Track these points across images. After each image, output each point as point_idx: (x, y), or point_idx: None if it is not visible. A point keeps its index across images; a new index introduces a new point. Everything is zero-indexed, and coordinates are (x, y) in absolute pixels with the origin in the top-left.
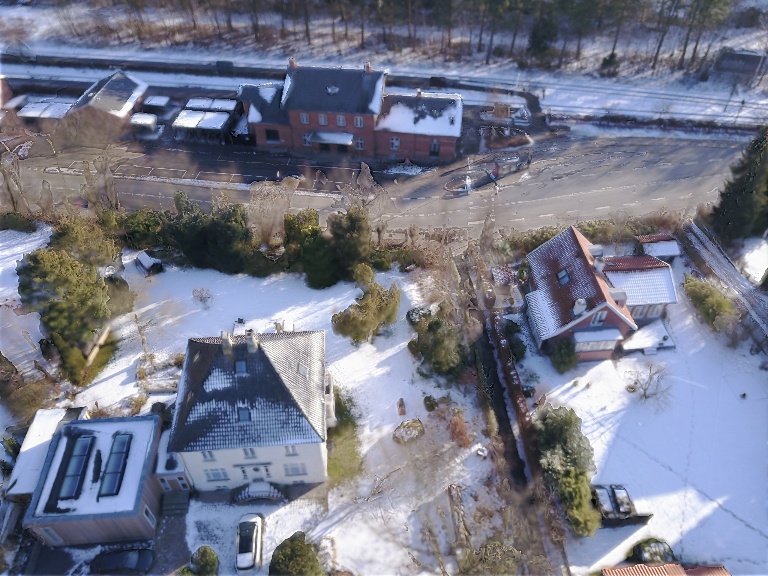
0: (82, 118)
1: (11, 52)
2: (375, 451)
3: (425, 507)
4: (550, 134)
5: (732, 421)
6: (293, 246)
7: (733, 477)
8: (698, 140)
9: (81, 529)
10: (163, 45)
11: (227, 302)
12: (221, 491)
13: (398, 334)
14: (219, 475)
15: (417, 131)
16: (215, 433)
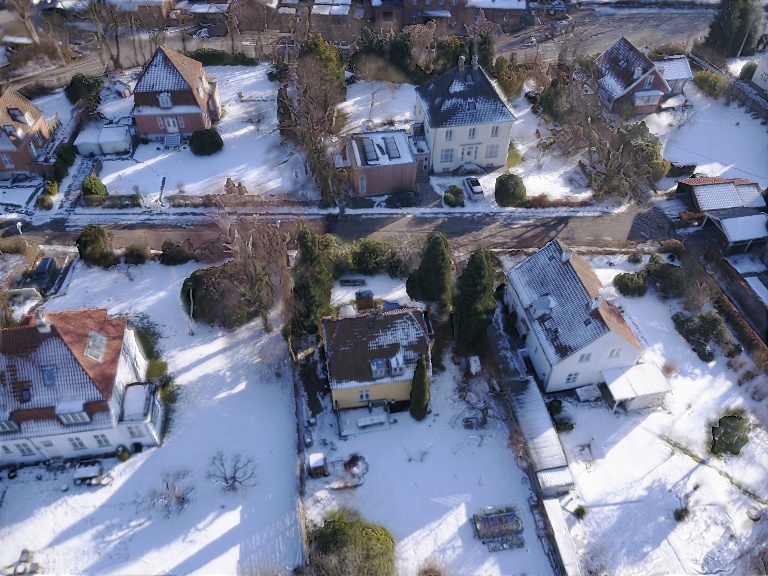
0: (243, 10)
1: None
2: (529, 153)
3: (567, 172)
4: (582, 13)
5: (732, 135)
6: (441, 63)
7: (737, 157)
8: (685, 13)
9: (381, 178)
10: None
11: (405, 96)
12: (445, 172)
13: (522, 106)
14: (448, 157)
15: (495, 6)
16: (456, 117)
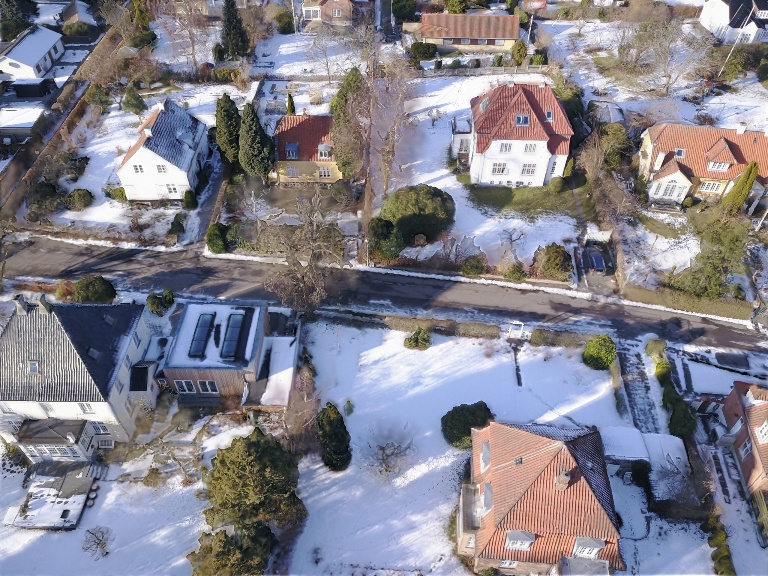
0: None
1: None
2: None
3: None
4: None
5: None
6: None
7: None
8: None
9: None
10: None
11: (77, 567)
12: None
13: None
14: None
15: None
16: None
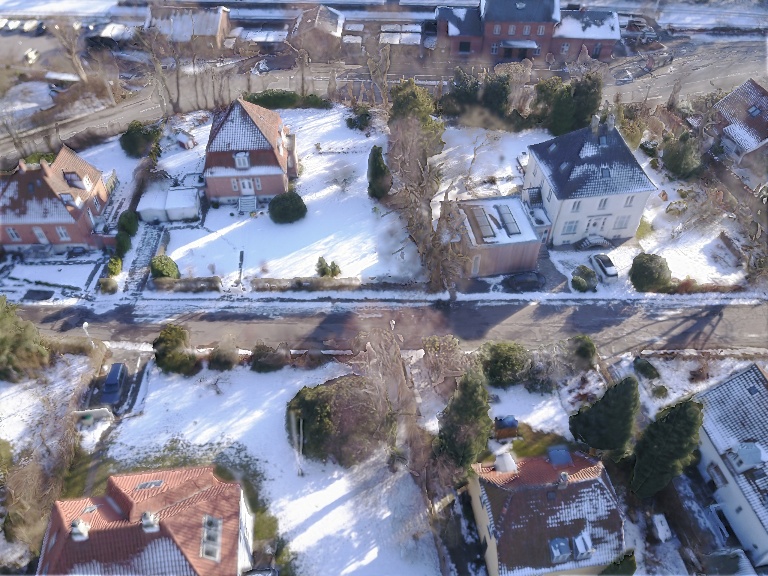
0: (305, 39)
1: None
2: (658, 220)
3: (707, 246)
4: (676, 42)
5: None
6: (540, 107)
7: None
8: None
9: (498, 258)
10: None
11: (502, 146)
12: (565, 245)
13: (637, 159)
14: (570, 229)
15: (587, 36)
16: (588, 186)
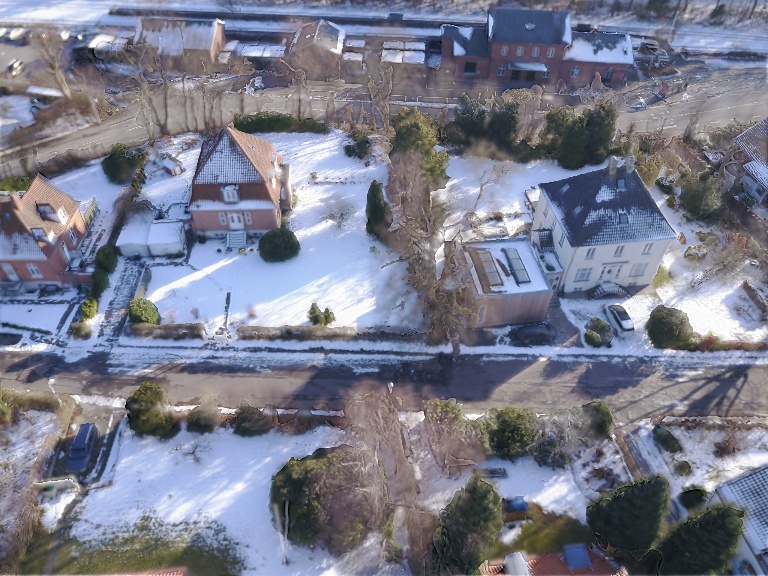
0: (304, 56)
1: (222, 3)
2: (676, 266)
3: (729, 296)
4: (690, 66)
5: None
6: (550, 137)
7: None
8: None
9: (505, 308)
10: (324, 4)
11: (509, 179)
12: (577, 292)
13: (653, 196)
14: (583, 276)
15: (598, 60)
16: (604, 233)
